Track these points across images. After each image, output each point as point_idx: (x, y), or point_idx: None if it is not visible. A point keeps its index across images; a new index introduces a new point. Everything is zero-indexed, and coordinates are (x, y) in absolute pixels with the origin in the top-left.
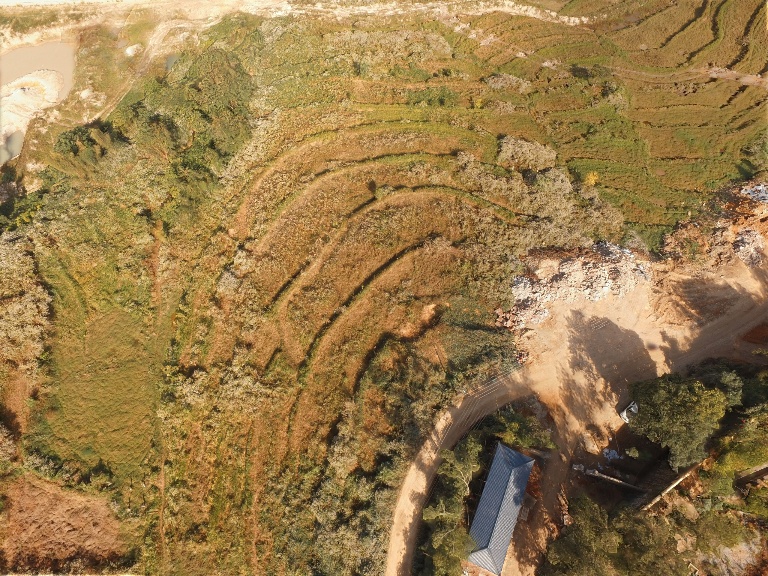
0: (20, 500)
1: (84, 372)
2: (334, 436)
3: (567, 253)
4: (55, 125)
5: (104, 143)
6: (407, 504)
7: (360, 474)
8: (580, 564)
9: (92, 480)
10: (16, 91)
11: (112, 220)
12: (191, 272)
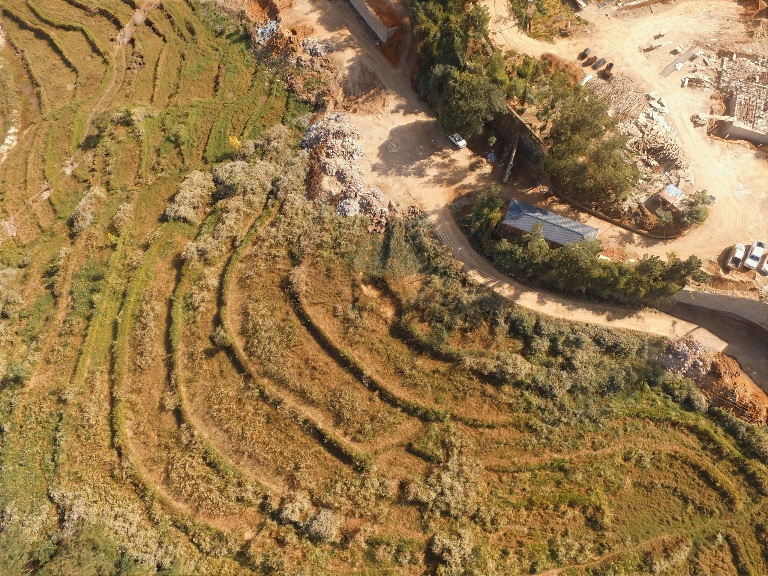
0: None
1: None
2: (496, 376)
3: (315, 169)
4: None
5: None
6: (548, 307)
7: (528, 350)
8: (598, 160)
9: None
10: None
11: None
12: None
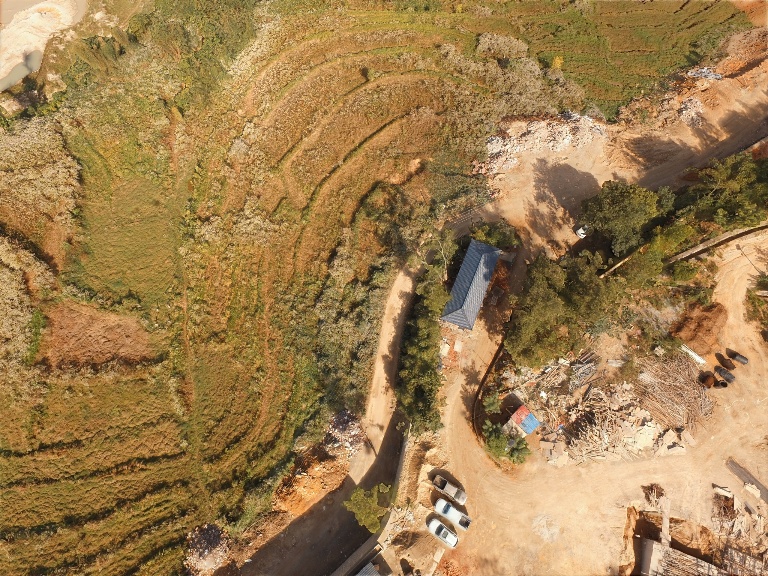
0: (61, 320)
1: (112, 225)
2: (334, 256)
3: (535, 117)
4: (71, 43)
5: (123, 41)
6: (396, 300)
7: (356, 282)
8: None
9: (124, 301)
10: (34, 14)
11: (132, 106)
12: (205, 144)
